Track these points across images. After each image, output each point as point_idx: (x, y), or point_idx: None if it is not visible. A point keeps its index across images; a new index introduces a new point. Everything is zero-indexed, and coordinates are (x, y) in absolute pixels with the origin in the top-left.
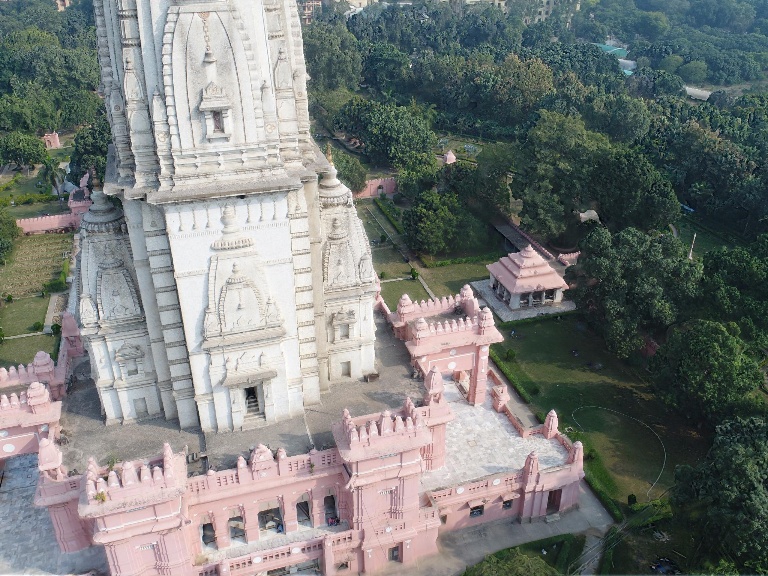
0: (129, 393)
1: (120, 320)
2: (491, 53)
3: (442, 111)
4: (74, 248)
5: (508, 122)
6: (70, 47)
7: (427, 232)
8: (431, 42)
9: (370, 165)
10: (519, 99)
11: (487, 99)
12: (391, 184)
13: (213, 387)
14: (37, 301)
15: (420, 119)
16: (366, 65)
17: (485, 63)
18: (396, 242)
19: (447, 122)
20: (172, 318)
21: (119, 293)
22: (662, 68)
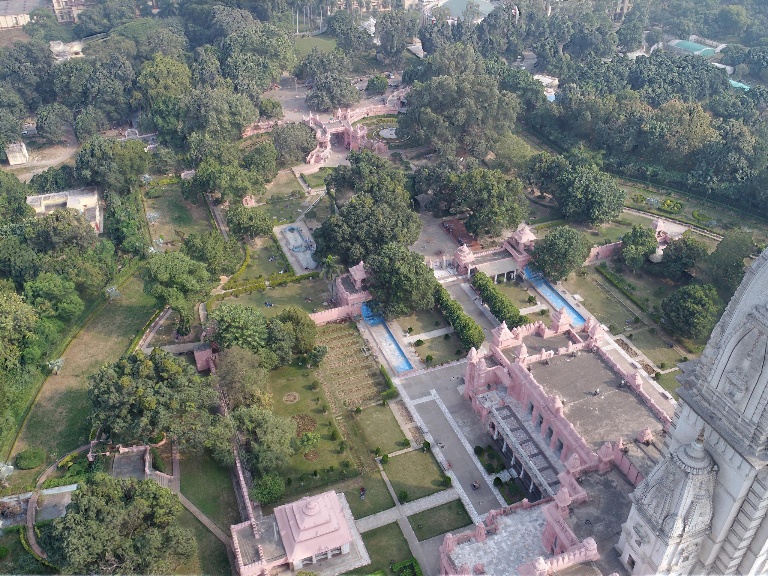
0: (675, 572)
1: (697, 530)
2: (608, 69)
3: (594, 147)
4: (368, 343)
5: (669, 164)
6: (208, 79)
7: (700, 326)
8: (539, 52)
9: (565, 222)
10: (686, 147)
11: (655, 146)
12: (606, 250)
13: (761, 573)
14: (381, 411)
15: (610, 177)
16: (498, 90)
17: (635, 100)
18: (647, 322)
19: (614, 166)
20: (751, 533)
21: (703, 514)
22: (764, 78)
